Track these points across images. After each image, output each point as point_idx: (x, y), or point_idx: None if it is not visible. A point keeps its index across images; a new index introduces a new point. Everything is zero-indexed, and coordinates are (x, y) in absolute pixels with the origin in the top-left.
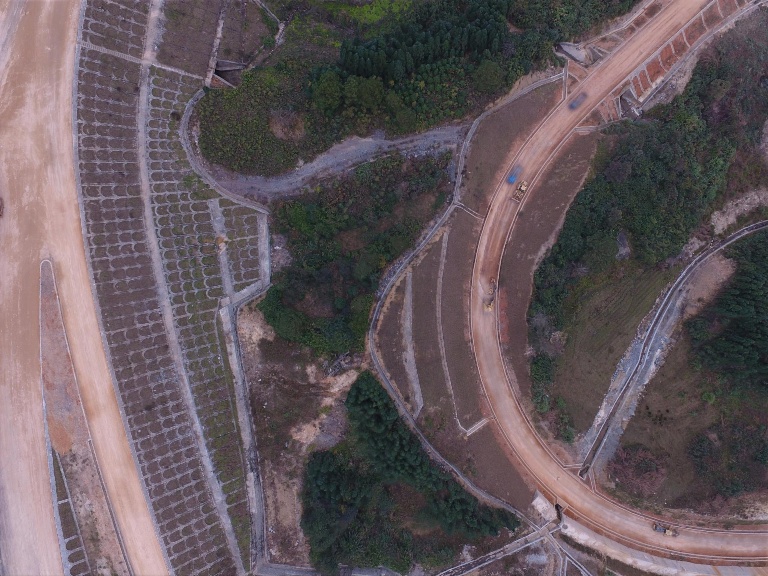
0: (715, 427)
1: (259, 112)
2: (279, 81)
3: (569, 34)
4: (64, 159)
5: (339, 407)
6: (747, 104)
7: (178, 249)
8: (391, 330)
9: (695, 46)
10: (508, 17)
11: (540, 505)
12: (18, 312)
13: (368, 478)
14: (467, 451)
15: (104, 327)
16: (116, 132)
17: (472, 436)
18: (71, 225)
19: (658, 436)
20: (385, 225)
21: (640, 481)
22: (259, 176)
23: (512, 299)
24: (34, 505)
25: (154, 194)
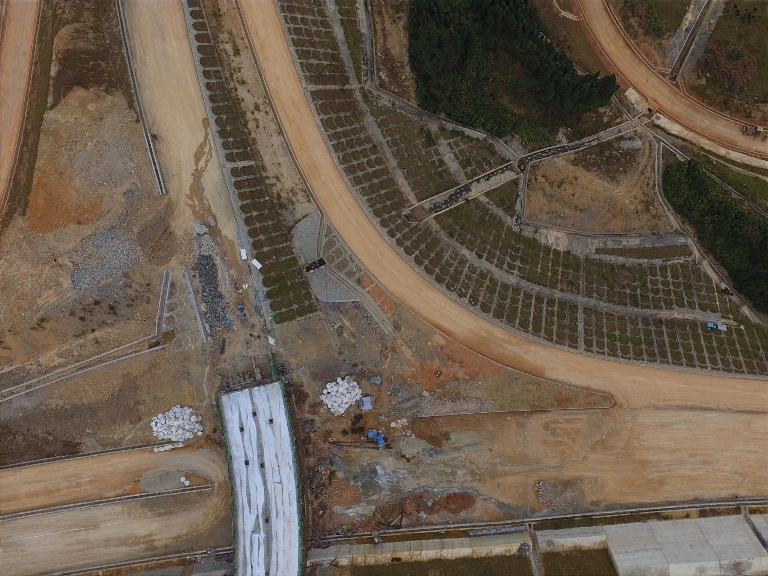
0: None
1: None
2: None
3: None
4: None
5: None
6: None
7: None
8: None
9: None
10: None
11: (633, 95)
12: None
13: None
14: (562, 28)
15: None
16: None
17: (566, 18)
18: None
19: (747, 34)
20: None
21: (732, 68)
22: None
23: None
24: None
25: None
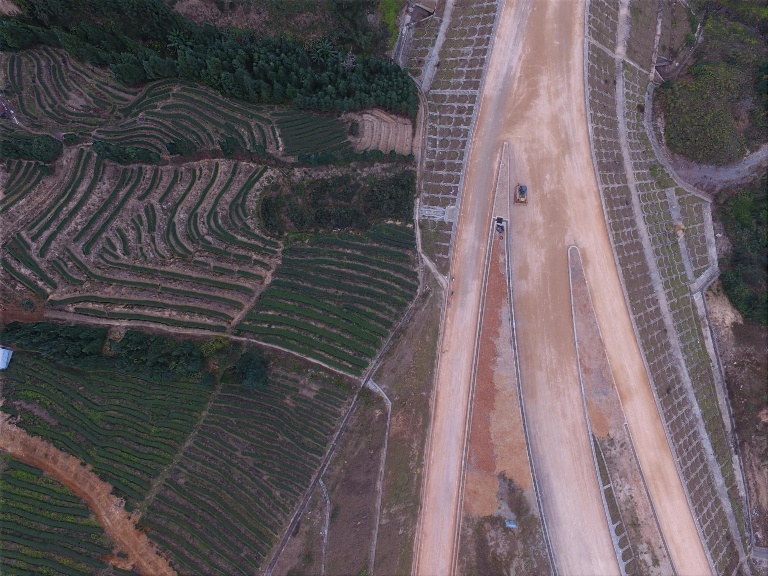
0: None
1: (724, 103)
2: (733, 74)
3: None
4: (580, 148)
5: None
6: None
7: (658, 236)
8: None
9: None
10: None
11: None
12: (548, 298)
13: None
14: None
15: (632, 311)
16: (608, 123)
17: None
18: (592, 212)
19: None
20: None
21: None
22: (711, 165)
23: None
24: (580, 491)
25: (637, 182)
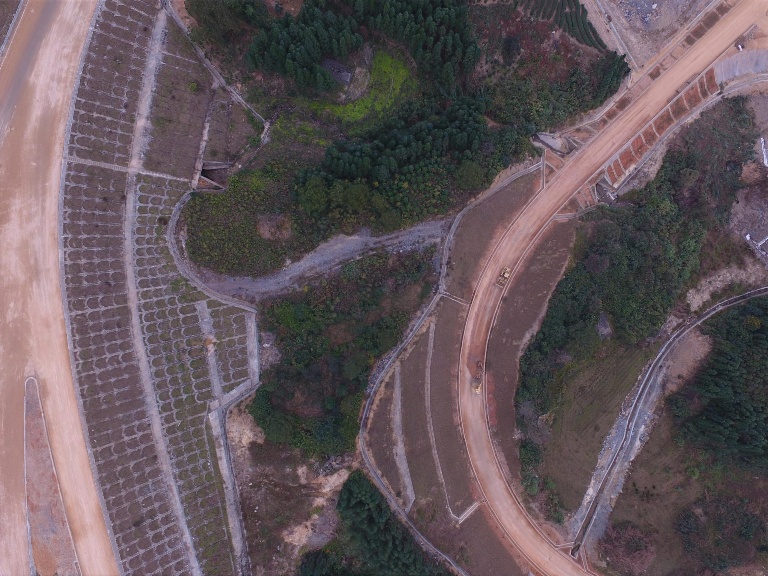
0: (700, 502)
1: (246, 216)
2: (265, 184)
3: (545, 126)
4: (50, 274)
5: (331, 506)
6: (715, 188)
7: (166, 355)
8: (381, 426)
9: (664, 136)
10: (486, 113)
11: None
12: (2, 432)
13: (361, 575)
14: (460, 539)
15: (91, 444)
16: (103, 242)
17: (464, 523)
18: (57, 341)
19: (646, 513)
20: (373, 317)
21: (630, 560)
22: (247, 277)
23: (499, 383)
24: None
25: (141, 301)
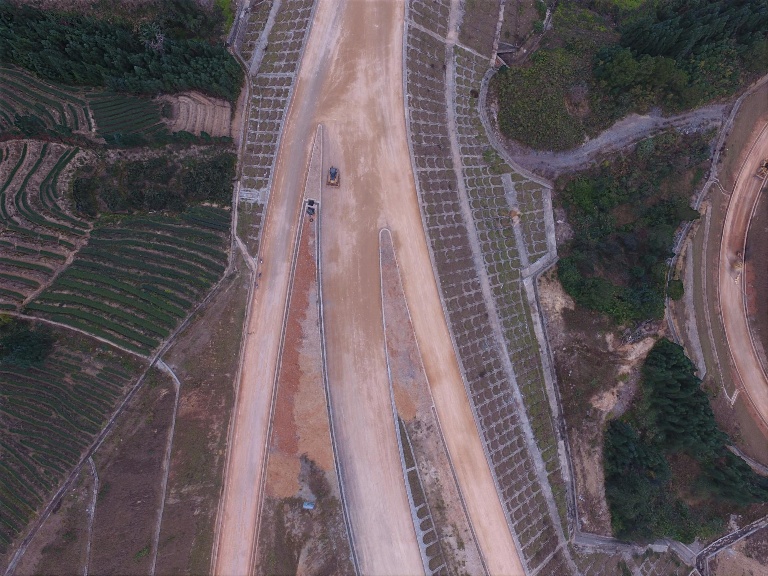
0: None
1: (557, 89)
2: (570, 60)
3: None
4: (396, 131)
5: (633, 375)
6: None
7: (486, 221)
8: None
9: None
10: None
11: None
12: (358, 280)
13: (654, 447)
14: (733, 420)
15: (443, 294)
16: (433, 107)
17: (735, 405)
18: (406, 195)
19: None
20: (652, 200)
21: None
22: (549, 151)
23: (761, 272)
24: (383, 473)
25: (464, 167)
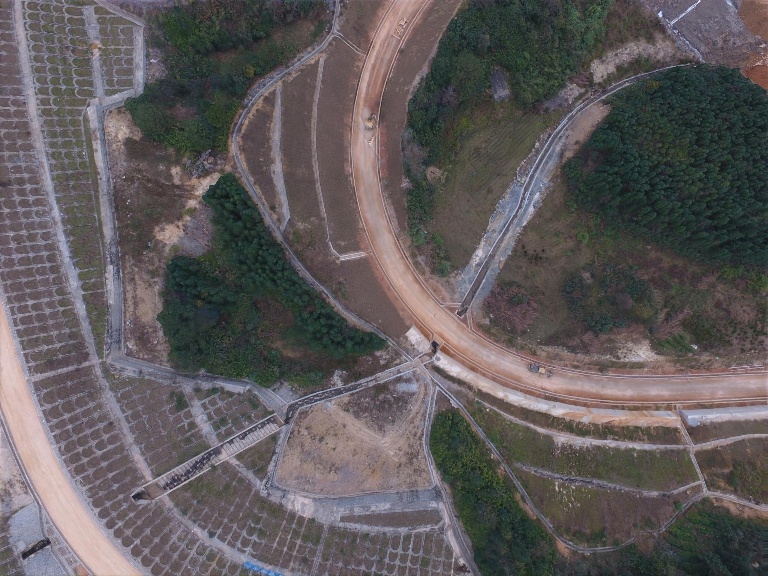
0: (588, 266)
1: None
2: None
3: None
4: None
5: (204, 211)
6: None
7: (47, 45)
8: (258, 139)
9: None
10: None
11: (413, 336)
12: None
13: (234, 289)
14: (339, 274)
15: None
16: None
17: (345, 262)
18: None
19: (533, 275)
20: None
21: (512, 314)
22: None
23: (390, 133)
24: None
25: None
